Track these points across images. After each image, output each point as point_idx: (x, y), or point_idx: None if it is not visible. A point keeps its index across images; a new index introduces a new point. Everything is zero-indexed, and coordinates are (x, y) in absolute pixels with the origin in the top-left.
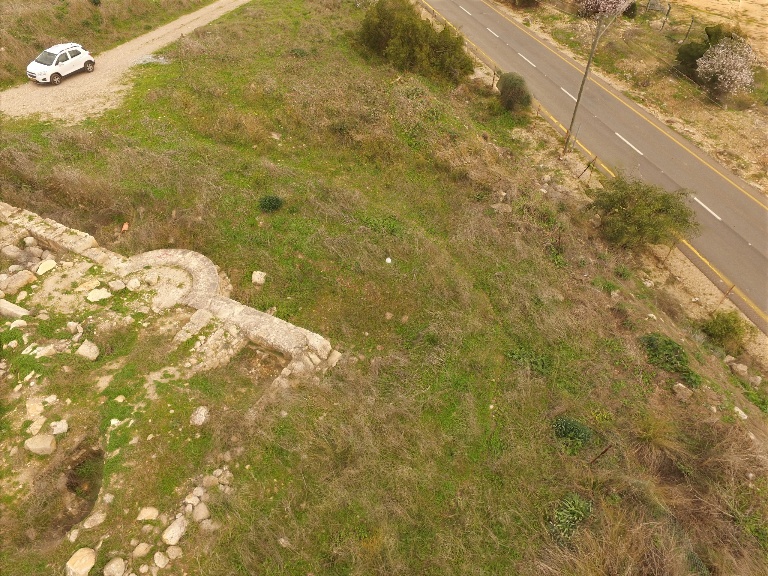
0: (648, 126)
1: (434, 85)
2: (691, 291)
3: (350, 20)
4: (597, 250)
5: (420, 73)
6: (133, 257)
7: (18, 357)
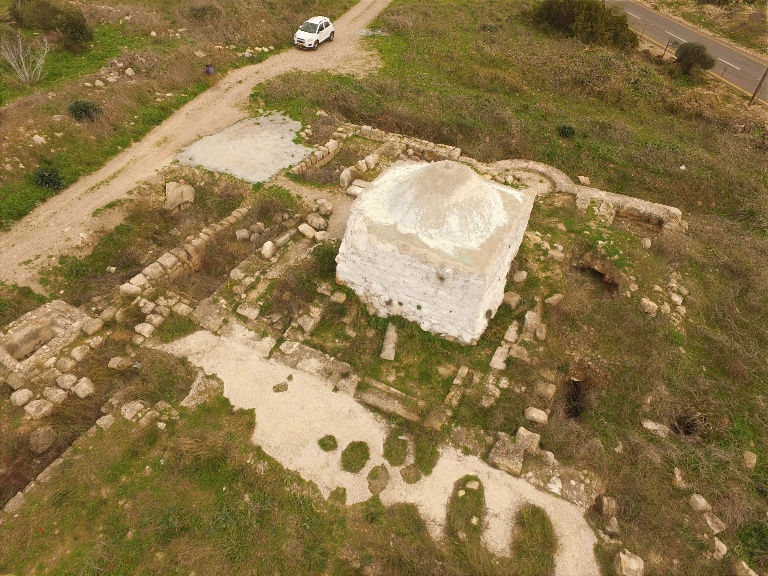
0: None
1: None
2: None
3: (510, 3)
4: None
5: (598, 45)
6: (492, 164)
7: None
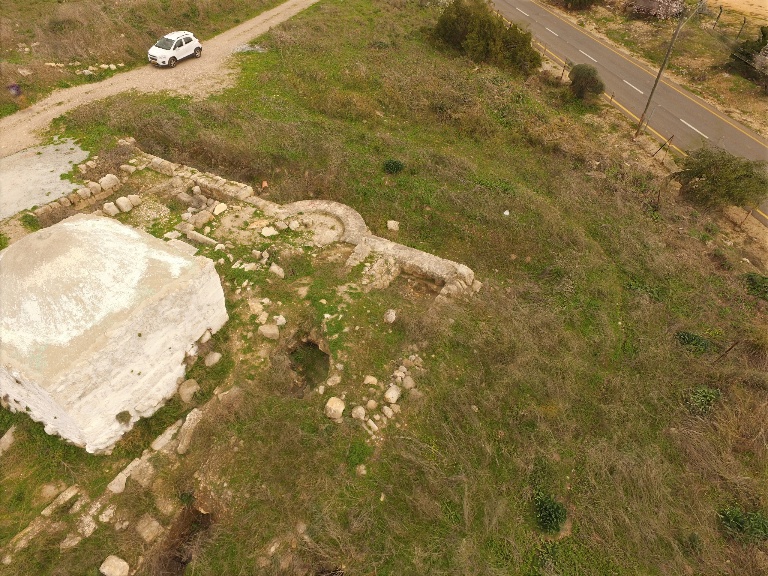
0: (709, 114)
1: (508, 75)
2: (767, 249)
3: (419, 18)
4: (688, 209)
5: (494, 65)
6: (286, 205)
7: (232, 269)
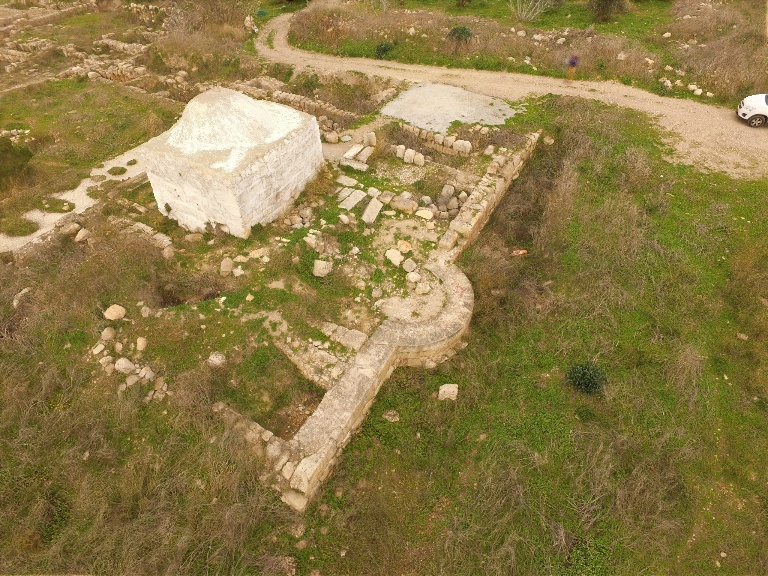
0: None
1: None
2: None
3: None
4: None
5: None
6: (455, 267)
7: None
